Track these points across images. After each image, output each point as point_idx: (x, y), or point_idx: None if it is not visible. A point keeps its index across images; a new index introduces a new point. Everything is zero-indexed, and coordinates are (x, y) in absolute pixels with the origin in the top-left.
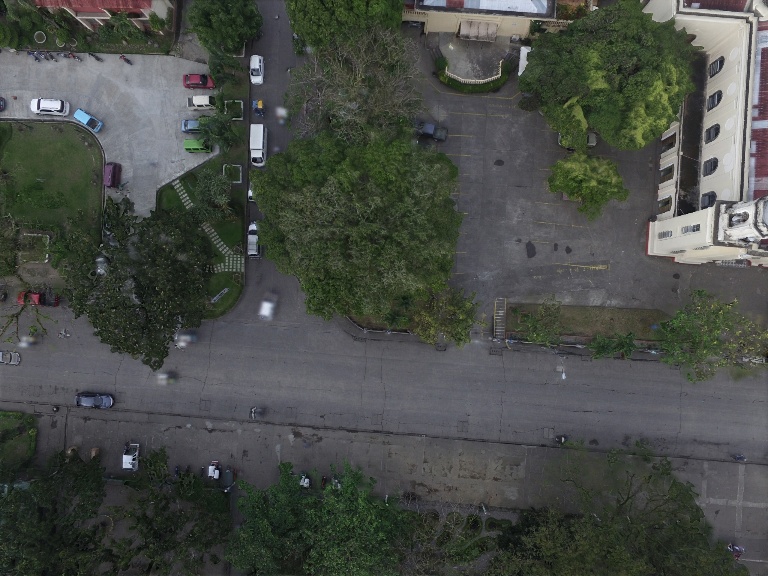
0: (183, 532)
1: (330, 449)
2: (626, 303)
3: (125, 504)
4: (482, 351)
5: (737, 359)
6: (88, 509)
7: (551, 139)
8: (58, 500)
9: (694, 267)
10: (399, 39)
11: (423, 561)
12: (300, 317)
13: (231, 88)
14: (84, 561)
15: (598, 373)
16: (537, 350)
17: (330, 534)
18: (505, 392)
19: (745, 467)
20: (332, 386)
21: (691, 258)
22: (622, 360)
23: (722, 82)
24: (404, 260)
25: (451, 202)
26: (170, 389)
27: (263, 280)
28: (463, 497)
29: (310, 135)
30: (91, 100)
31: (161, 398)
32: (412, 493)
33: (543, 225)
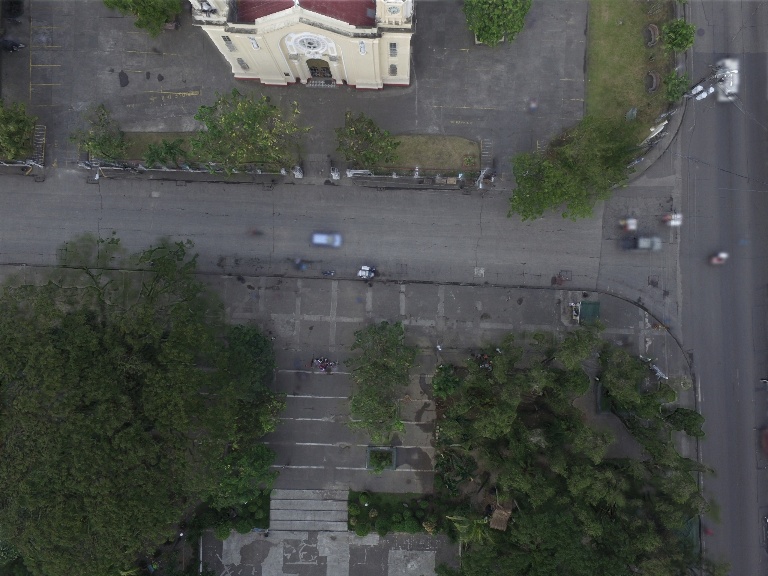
0: None
1: None
2: None
3: None
4: (79, 180)
5: None
6: None
7: None
8: None
9: (284, 89)
10: None
11: None
12: None
13: None
14: None
15: (192, 197)
16: (131, 177)
17: None
18: (102, 219)
19: (338, 283)
20: None
21: (261, 73)
22: None
23: None
24: None
25: None
26: None
27: None
28: None
29: None
30: None
31: None
32: None
33: (135, 54)
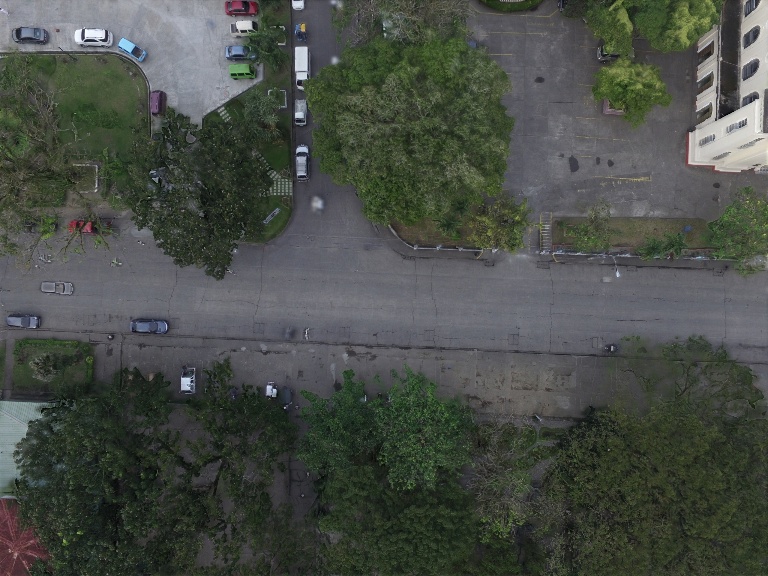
0: (253, 437)
1: (384, 366)
2: (668, 213)
3: (184, 427)
4: (530, 265)
5: None
6: (161, 414)
7: (590, 55)
8: (129, 408)
9: (733, 176)
10: None
11: (492, 450)
12: (349, 238)
13: (272, 15)
14: (163, 459)
15: (644, 282)
16: (583, 262)
17: (402, 426)
18: (554, 304)
19: None
20: (384, 304)
21: (732, 163)
22: (667, 268)
23: None
24: (465, 154)
25: (502, 107)
26: (223, 313)
27: (311, 203)
28: (516, 408)
29: (364, 42)
30: (134, 31)
31: (215, 323)
32: (466, 406)
33: (585, 139)
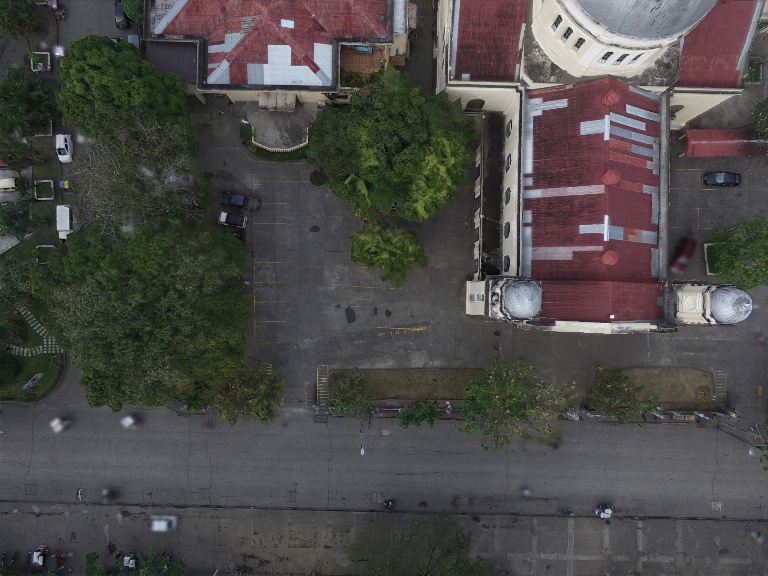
0: None
1: (159, 526)
2: (448, 363)
3: None
4: (306, 419)
5: (562, 413)
6: None
7: None
8: None
9: None
10: (169, 126)
11: None
12: None
13: (41, 167)
14: None
15: (423, 435)
16: (361, 415)
17: None
18: (331, 459)
19: (574, 520)
20: (158, 463)
21: None
22: None
23: (511, 146)
24: (168, 356)
25: (239, 284)
26: None
27: None
28: (294, 567)
29: (85, 227)
30: None
31: None
32: (243, 566)
33: (362, 289)
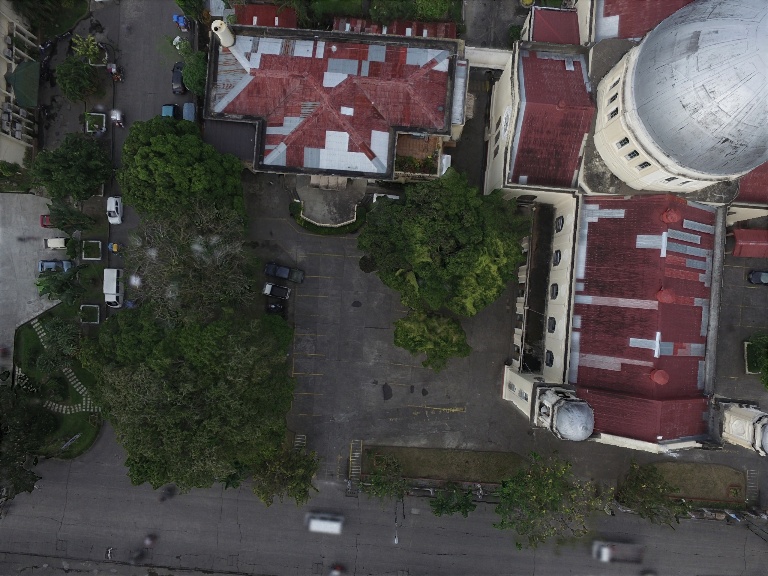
0: None
1: None
2: (482, 446)
3: None
4: (338, 493)
5: None
6: None
7: None
8: None
9: None
10: (227, 210)
11: None
12: None
13: None
14: None
15: (453, 516)
16: None
17: None
18: (360, 534)
19: None
20: (188, 527)
21: None
22: None
23: (561, 243)
24: (216, 446)
25: (284, 367)
26: (27, 529)
27: None
28: None
29: (137, 306)
30: None
31: (18, 538)
32: None
33: (400, 367)
